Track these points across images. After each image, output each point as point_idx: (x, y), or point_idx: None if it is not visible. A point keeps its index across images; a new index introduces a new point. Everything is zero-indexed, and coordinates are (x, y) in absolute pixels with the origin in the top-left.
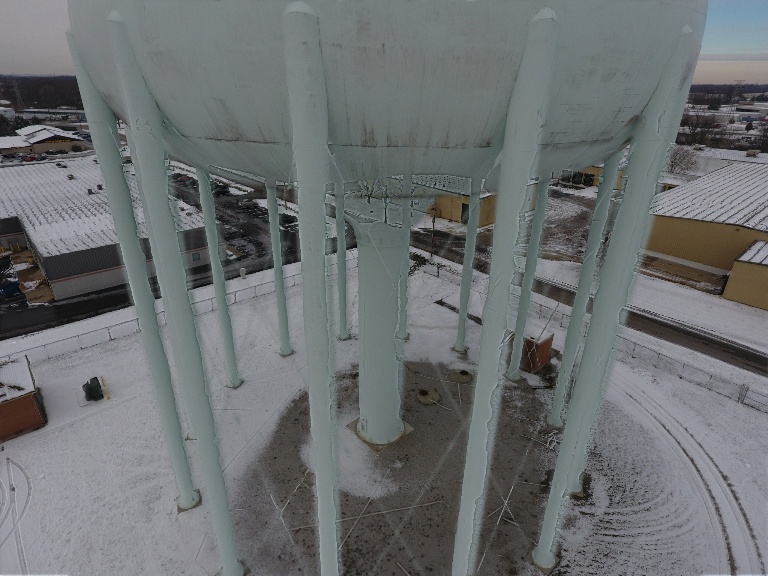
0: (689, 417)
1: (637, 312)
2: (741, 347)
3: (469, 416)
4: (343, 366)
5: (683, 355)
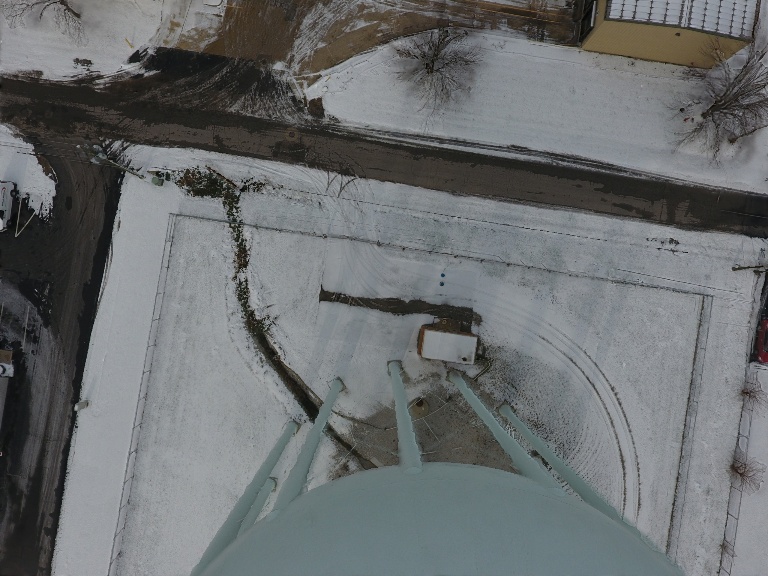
0: (585, 335)
1: (508, 157)
2: (607, 171)
3: (451, 449)
4: (327, 464)
5: (564, 227)
